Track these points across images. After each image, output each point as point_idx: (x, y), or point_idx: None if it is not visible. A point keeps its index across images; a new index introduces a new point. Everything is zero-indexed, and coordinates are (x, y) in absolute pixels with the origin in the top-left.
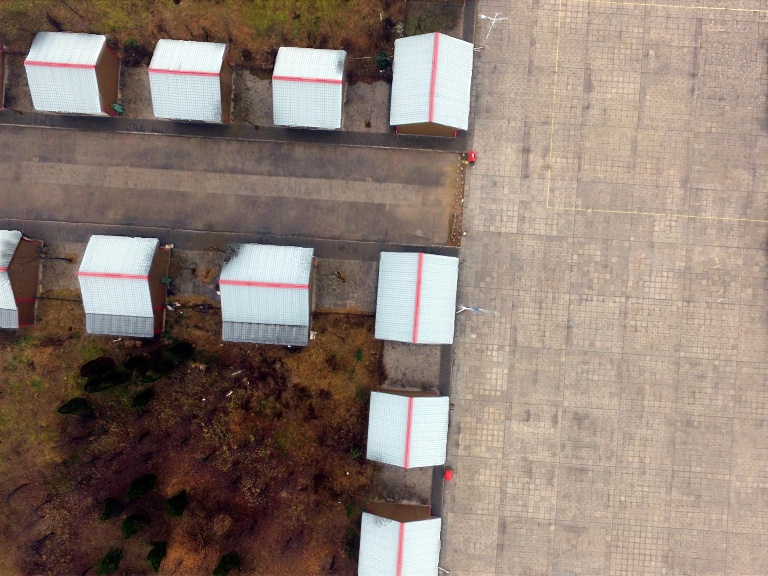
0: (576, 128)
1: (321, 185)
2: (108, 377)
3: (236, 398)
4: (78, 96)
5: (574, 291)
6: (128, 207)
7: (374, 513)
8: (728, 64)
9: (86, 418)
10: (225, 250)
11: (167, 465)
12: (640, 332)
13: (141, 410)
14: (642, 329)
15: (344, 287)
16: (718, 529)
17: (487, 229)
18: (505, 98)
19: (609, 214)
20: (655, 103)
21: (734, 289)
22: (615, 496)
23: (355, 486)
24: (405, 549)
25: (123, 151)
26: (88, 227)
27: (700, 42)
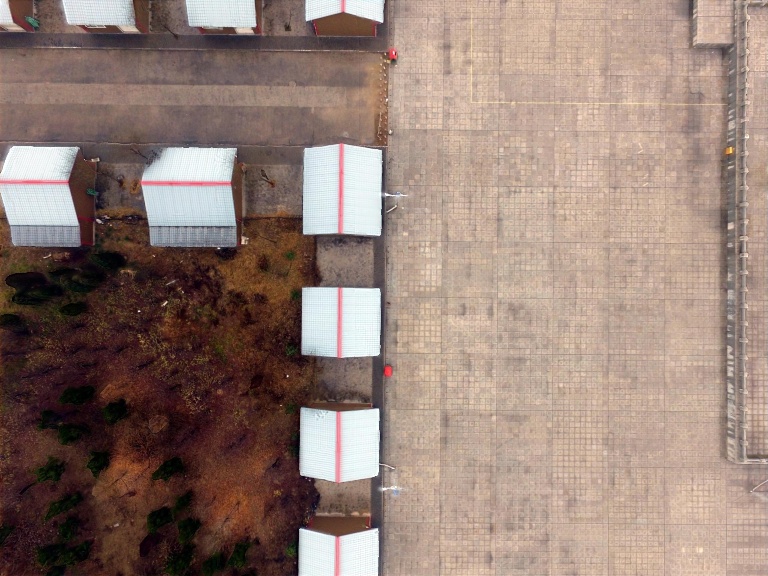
0: (495, 22)
1: (245, 92)
2: (37, 288)
3: (171, 308)
4: None
5: (502, 184)
6: (51, 123)
7: (312, 407)
8: None
9: (19, 334)
10: None
11: (105, 378)
12: (569, 220)
13: (76, 325)
14: (571, 217)
15: (274, 192)
16: (656, 409)
17: (413, 127)
18: None
19: (532, 106)
20: None
21: (659, 173)
22: (553, 383)
23: (296, 388)
24: (343, 438)
25: (43, 67)
26: (11, 145)
27: None
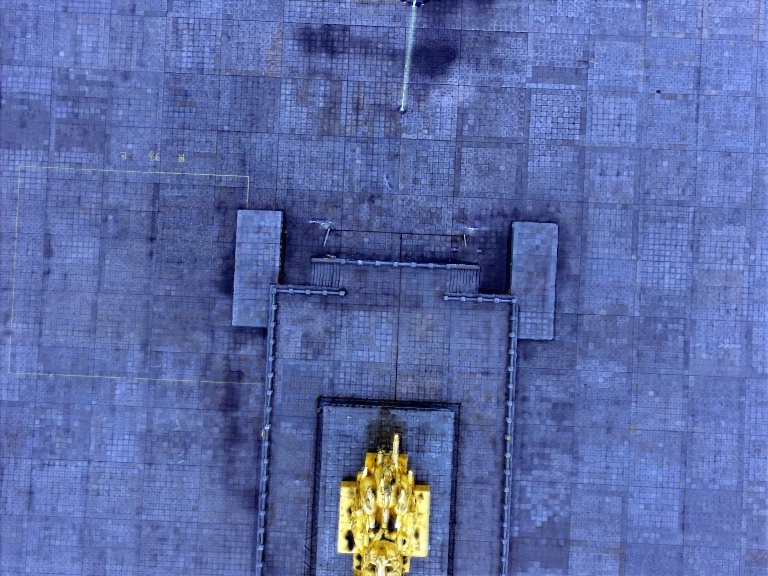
0: (37, 293)
1: None
2: None
3: None
4: None
5: (36, 456)
6: None
7: None
8: (186, 228)
9: None
10: None
11: None
12: (102, 496)
13: None
14: (104, 493)
15: None
16: None
17: None
18: None
19: (71, 378)
20: (115, 267)
21: (195, 450)
22: None
23: None
24: None
25: None
26: None
27: (158, 206)
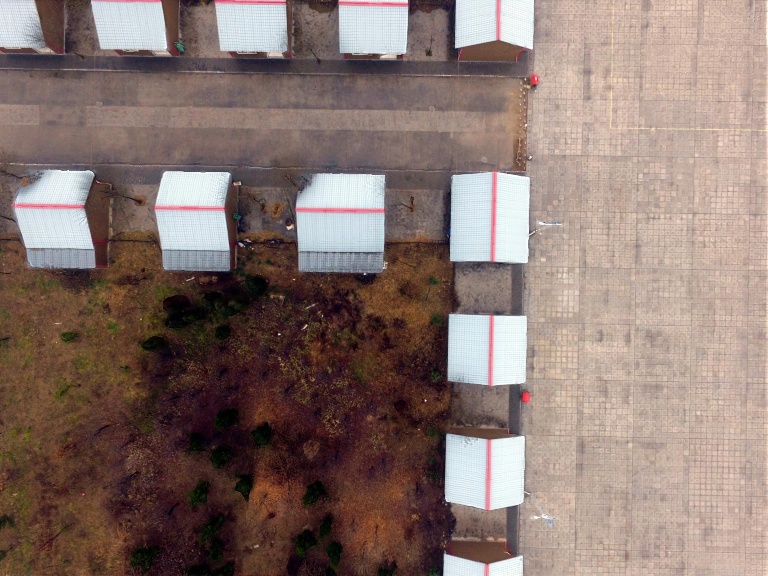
0: (636, 47)
1: (385, 116)
2: (187, 312)
3: (311, 331)
4: (145, 32)
5: (641, 210)
6: (194, 147)
7: (458, 434)
8: None
9: (165, 357)
10: (294, 184)
11: (246, 400)
12: (708, 247)
13: (218, 347)
14: (710, 244)
15: (412, 217)
16: None
17: (552, 152)
18: (564, 21)
19: (672, 132)
20: (714, 19)
21: None
22: (691, 411)
23: (433, 413)
24: (493, 466)
25: (186, 91)
26: (155, 168)
27: None
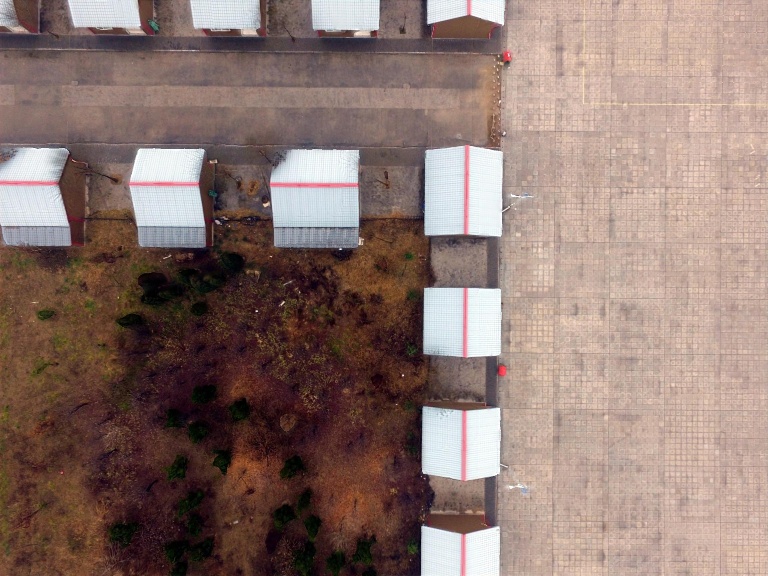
0: (607, 24)
1: (360, 94)
2: (163, 289)
3: (288, 308)
4: (118, 9)
5: (614, 185)
6: (170, 126)
7: (434, 406)
8: None
9: (142, 334)
10: (270, 161)
11: (224, 377)
12: (681, 221)
13: (195, 324)
14: (683, 218)
15: (388, 193)
16: (767, 408)
17: (526, 128)
18: None
19: (644, 107)
20: None
21: None
22: (665, 383)
23: (411, 387)
24: (468, 437)
25: (161, 70)
26: (131, 147)
27: None
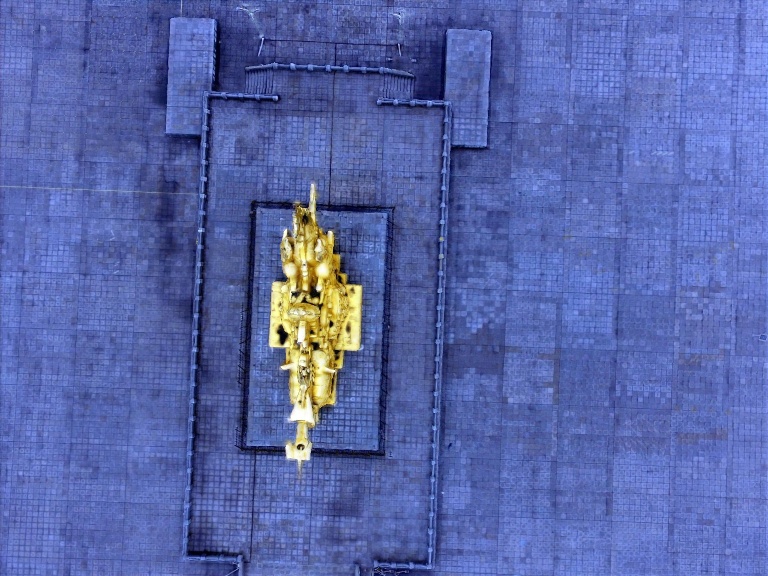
0: None
1: None
2: None
3: None
4: None
5: None
6: None
7: None
8: (119, 38)
9: None
10: None
11: None
12: (37, 306)
13: None
14: (39, 303)
15: None
16: (116, 500)
17: None
18: None
19: (4, 189)
20: (48, 78)
21: (130, 261)
22: (13, 471)
23: None
24: None
25: None
26: None
27: (91, 17)
